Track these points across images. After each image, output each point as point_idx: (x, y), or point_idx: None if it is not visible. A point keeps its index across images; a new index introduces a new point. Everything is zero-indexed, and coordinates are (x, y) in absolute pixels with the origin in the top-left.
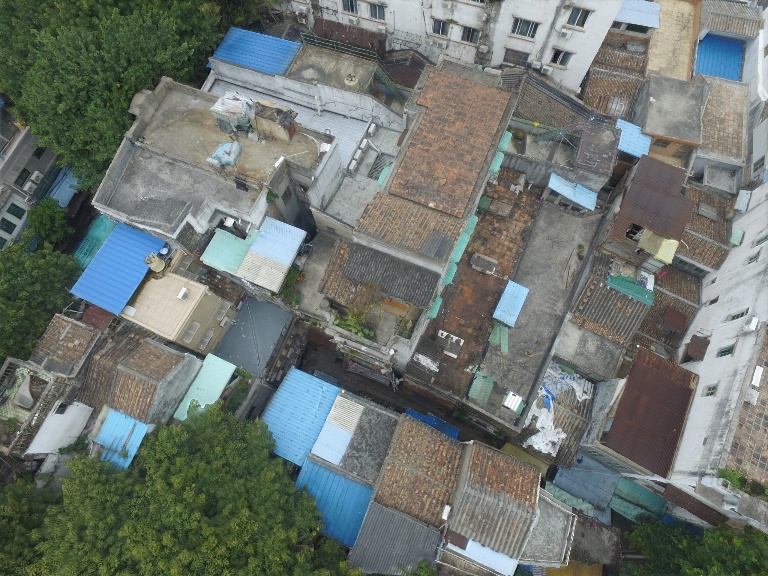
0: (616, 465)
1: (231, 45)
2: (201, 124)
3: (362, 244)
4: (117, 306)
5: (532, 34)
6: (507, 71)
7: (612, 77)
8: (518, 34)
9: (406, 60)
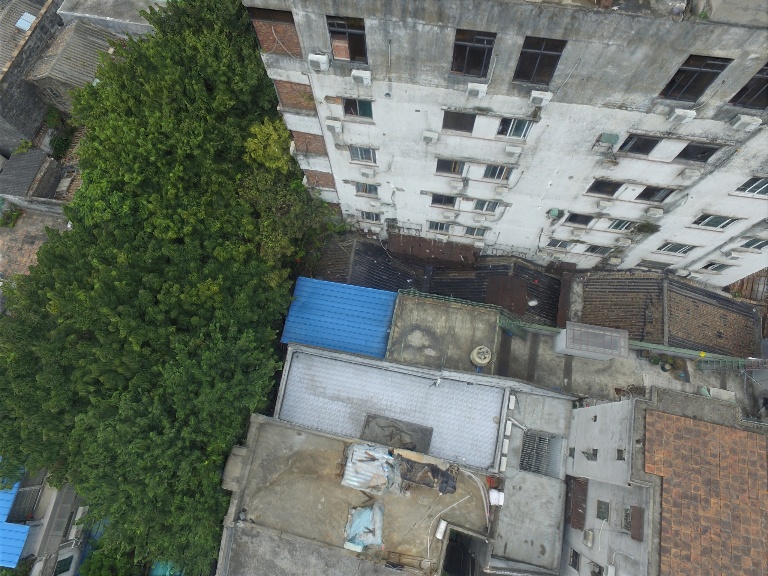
0: None
1: (304, 304)
2: (317, 475)
3: None
4: None
5: (684, 251)
6: (640, 275)
7: None
8: (665, 250)
9: (507, 268)
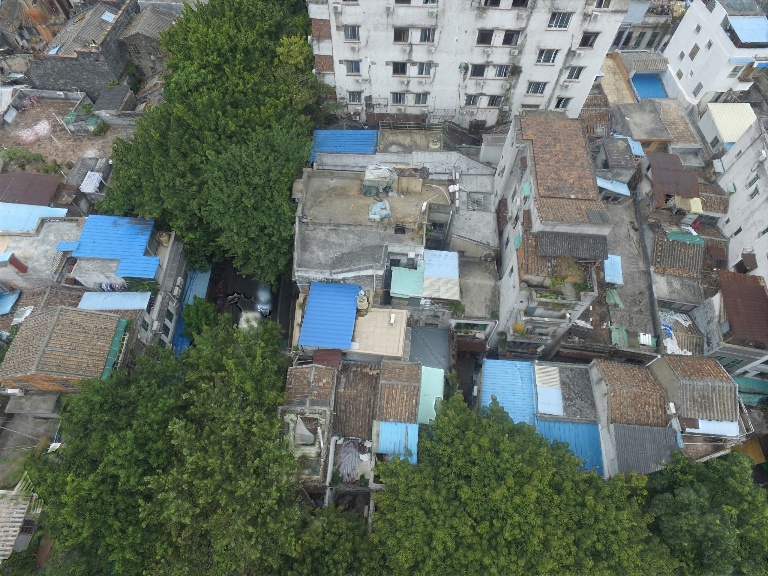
0: (733, 363)
1: (320, 143)
2: (347, 196)
3: (545, 231)
4: (346, 343)
5: (541, 91)
6: None
7: (590, 112)
8: (531, 93)
9: None
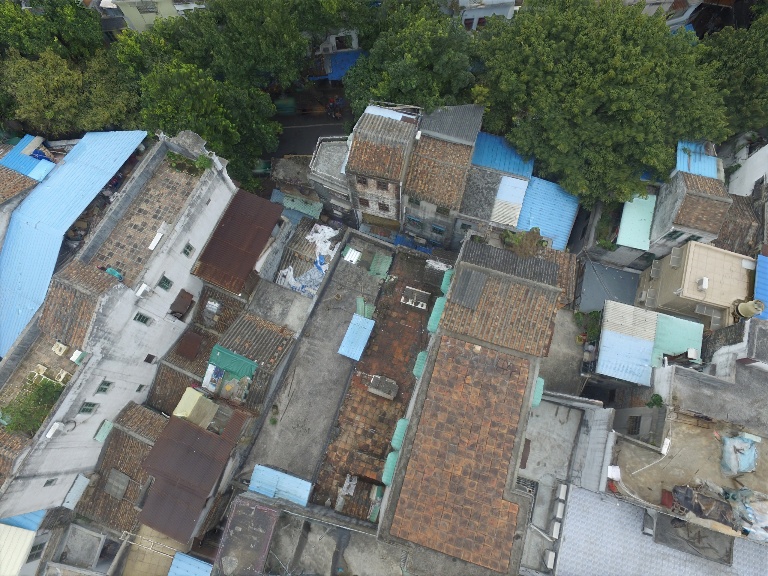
0: None
1: None
2: None
3: None
4: (765, 263)
5: None
6: None
7: None
8: None
9: None
